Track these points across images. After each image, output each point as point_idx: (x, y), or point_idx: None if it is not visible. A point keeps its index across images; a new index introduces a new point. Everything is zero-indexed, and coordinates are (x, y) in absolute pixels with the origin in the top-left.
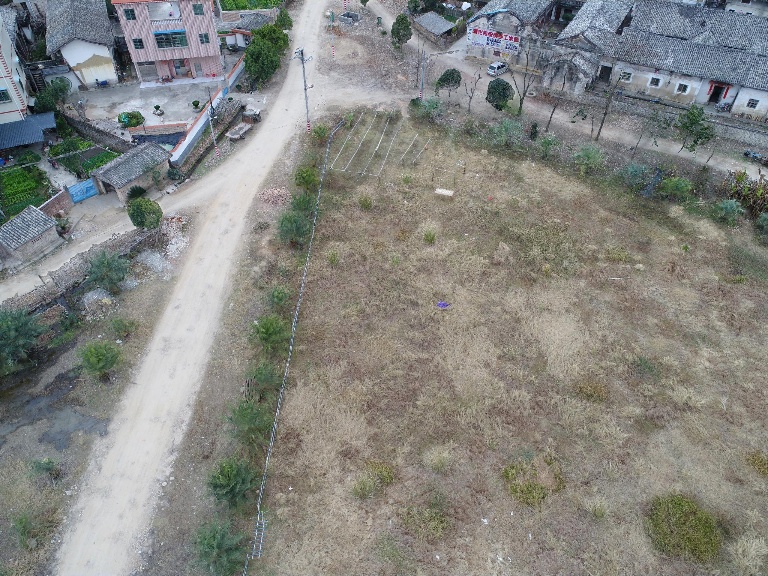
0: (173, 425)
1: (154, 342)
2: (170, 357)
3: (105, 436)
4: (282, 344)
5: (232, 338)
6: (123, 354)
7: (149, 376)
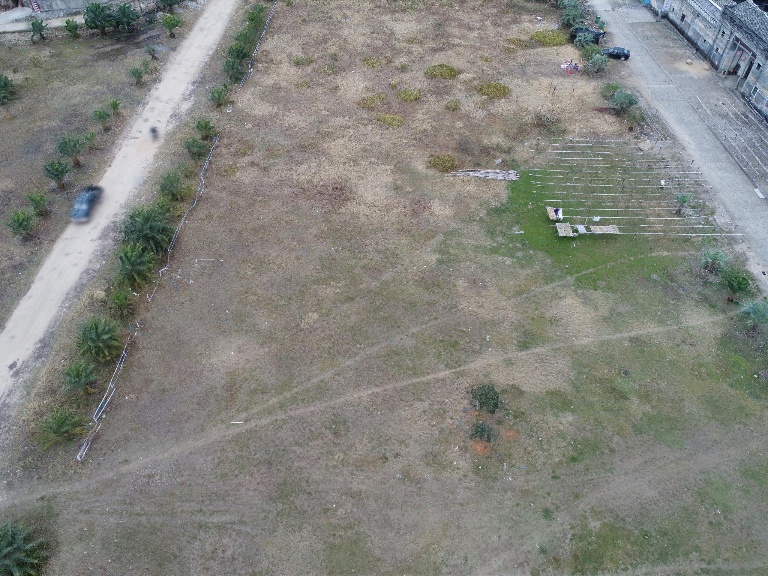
0: (208, 49)
1: (195, 28)
2: (204, 32)
3: (176, 51)
4: (261, 29)
5: (235, 27)
6: (180, 31)
7: (194, 37)
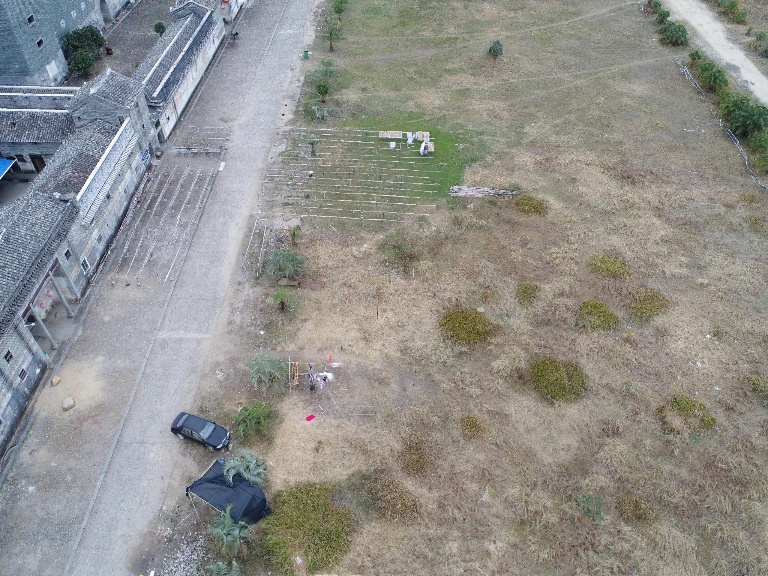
0: None
1: None
2: None
3: None
4: None
5: None
6: None
7: None
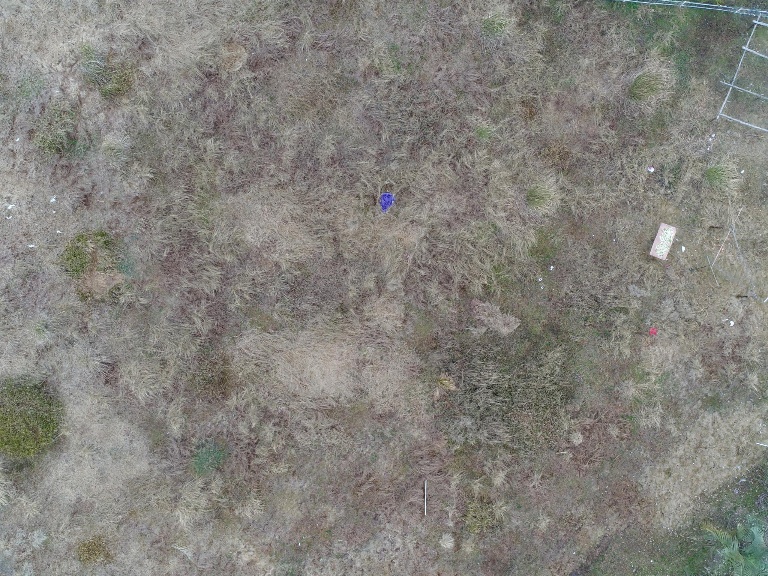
0: None
1: None
2: None
3: None
4: None
5: None
6: None
7: None
